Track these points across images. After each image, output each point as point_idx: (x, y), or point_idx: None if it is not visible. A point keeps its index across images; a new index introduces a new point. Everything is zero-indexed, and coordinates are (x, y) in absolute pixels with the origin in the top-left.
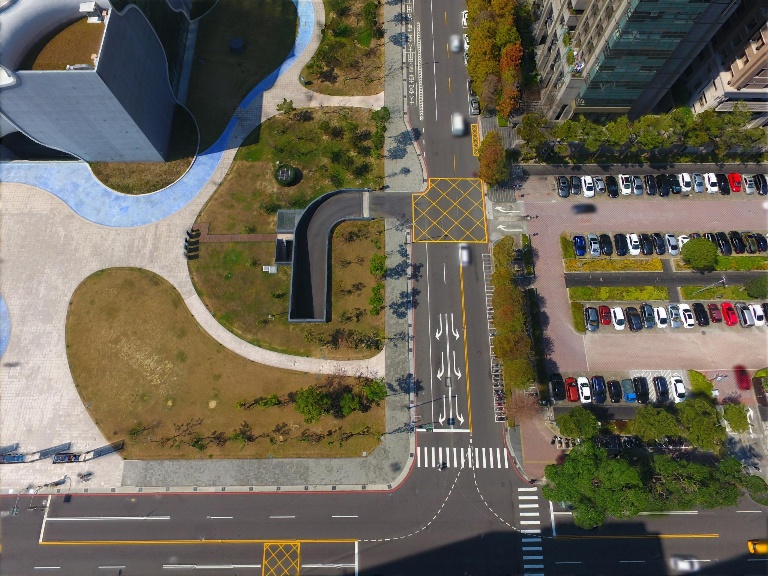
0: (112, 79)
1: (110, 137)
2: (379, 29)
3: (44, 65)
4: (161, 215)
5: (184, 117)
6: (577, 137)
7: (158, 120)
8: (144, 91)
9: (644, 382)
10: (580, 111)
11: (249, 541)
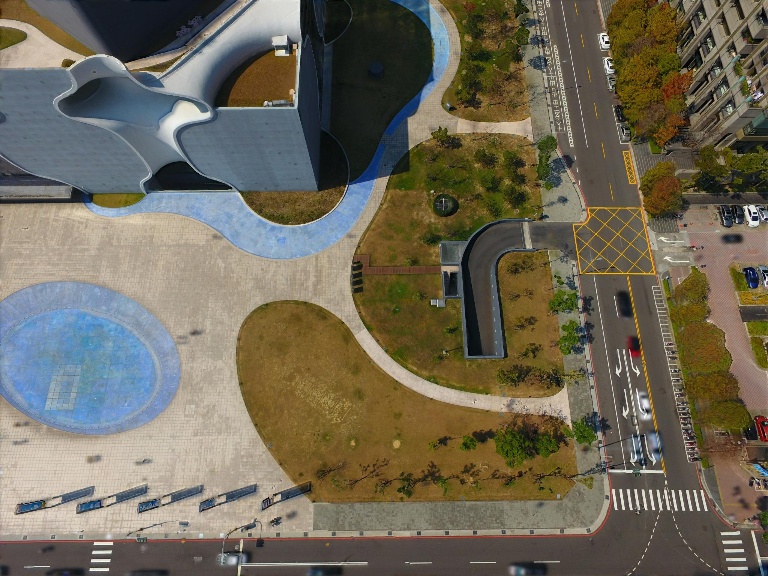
0: (302, 114)
1: (276, 168)
2: (516, 52)
3: (239, 101)
4: (320, 246)
5: (332, 144)
6: (759, 169)
7: (315, 149)
8: (311, 122)
9: None
10: (747, 140)
11: None
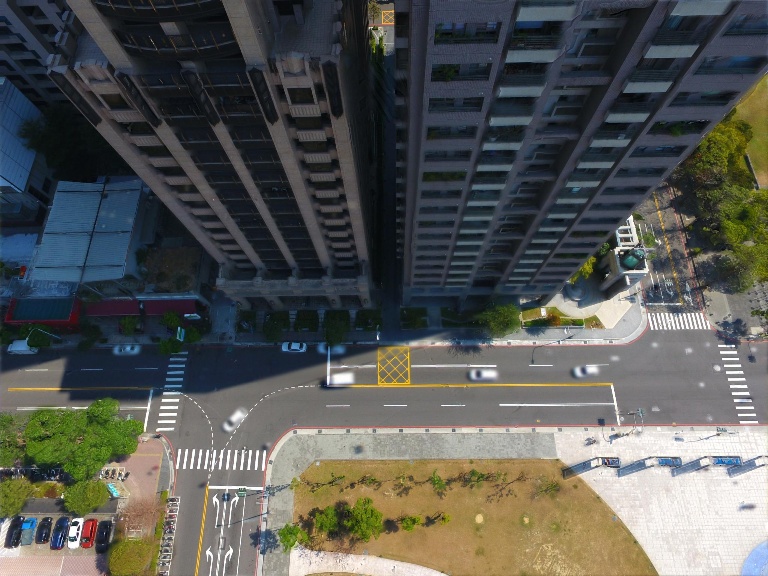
0: None
1: None
2: None
3: None
4: None
5: None
6: None
7: None
8: None
9: (6, 542)
10: None
11: (424, 386)
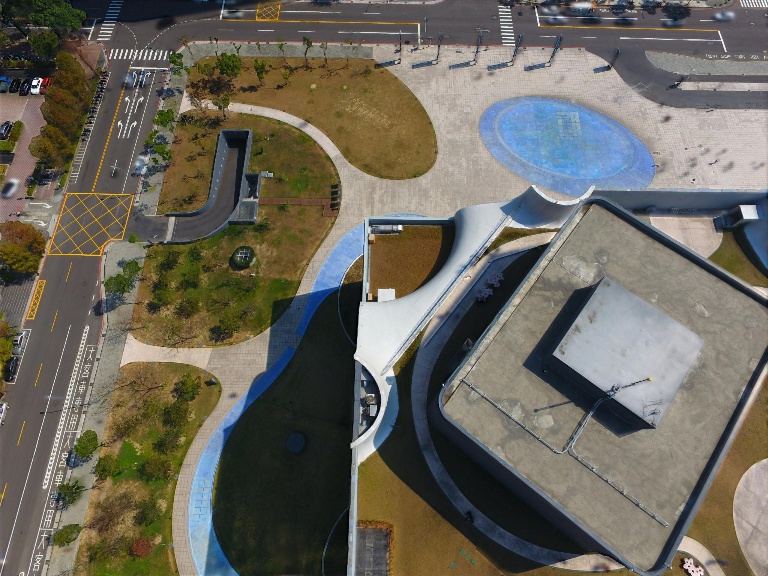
0: None
1: None
2: None
3: (430, 237)
4: None
5: None
6: None
7: None
8: None
9: None
10: None
11: (287, 21)
